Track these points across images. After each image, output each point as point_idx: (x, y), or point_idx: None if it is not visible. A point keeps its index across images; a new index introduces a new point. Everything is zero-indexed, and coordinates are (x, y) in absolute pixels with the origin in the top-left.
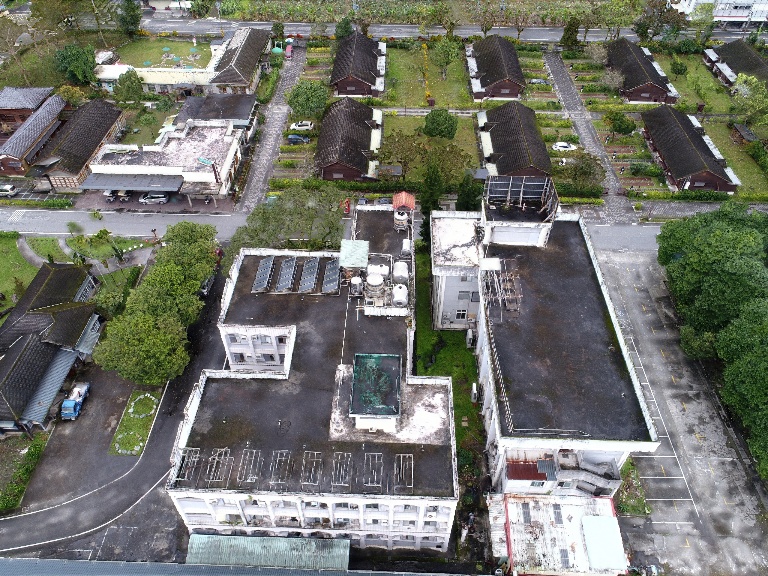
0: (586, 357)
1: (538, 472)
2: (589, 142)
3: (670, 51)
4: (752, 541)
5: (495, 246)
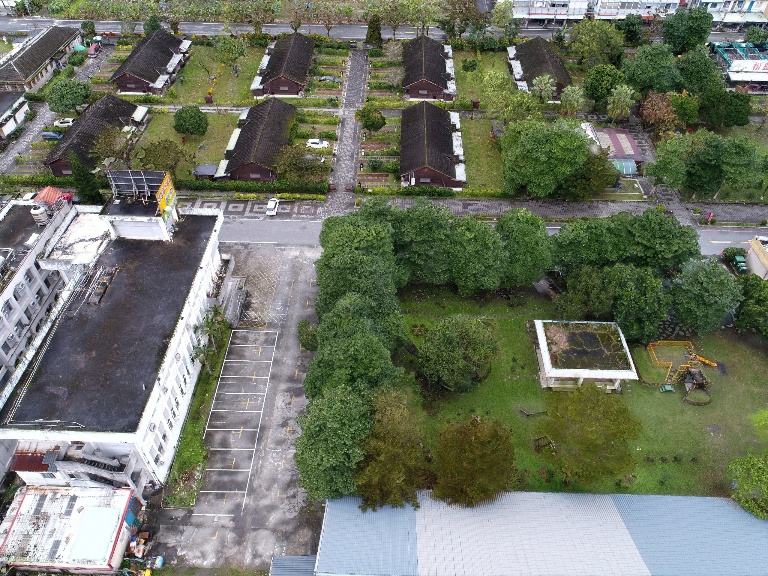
0: (134, 350)
1: (42, 463)
2: (348, 139)
3: (476, 49)
4: (282, 533)
5: (121, 240)
